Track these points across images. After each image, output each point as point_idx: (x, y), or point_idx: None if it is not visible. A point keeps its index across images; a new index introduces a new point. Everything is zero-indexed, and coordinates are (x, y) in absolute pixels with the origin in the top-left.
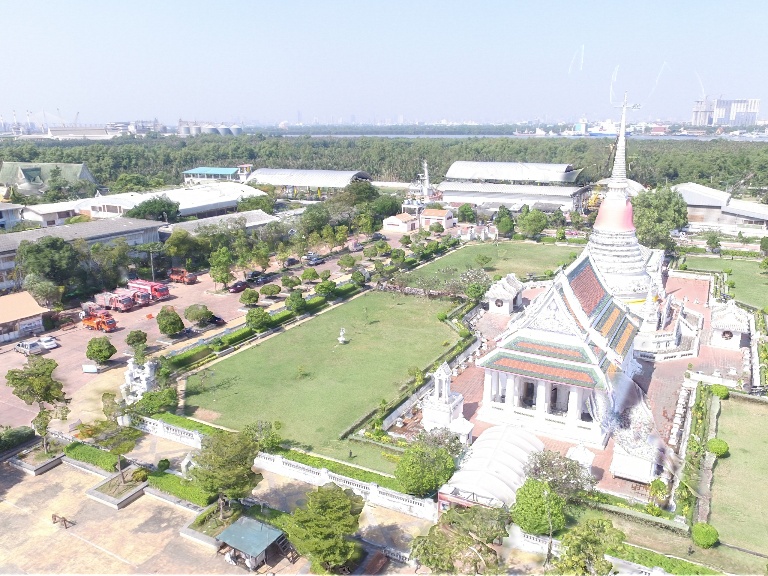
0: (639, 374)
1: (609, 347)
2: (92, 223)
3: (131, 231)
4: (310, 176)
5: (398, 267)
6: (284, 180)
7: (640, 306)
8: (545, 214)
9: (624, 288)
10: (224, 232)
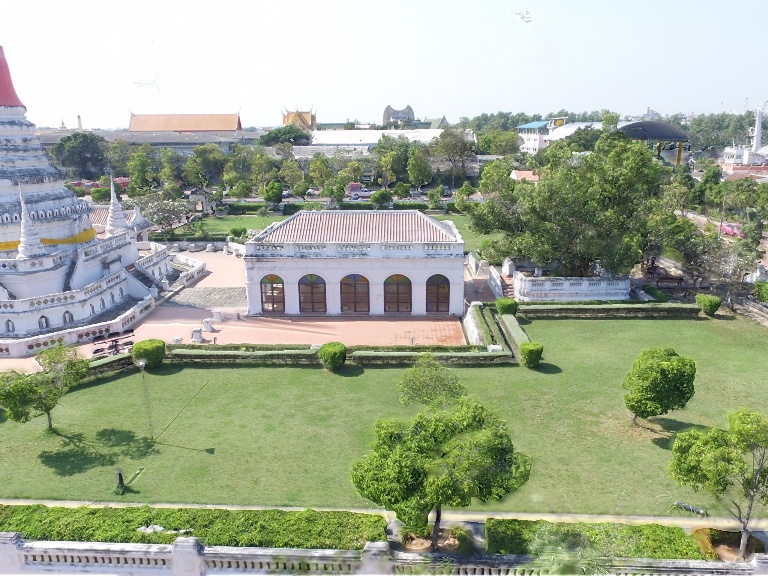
0: None
1: None
2: None
3: (186, 143)
4: None
5: (270, 207)
6: (568, 134)
7: None
8: (730, 187)
9: None
10: (248, 154)
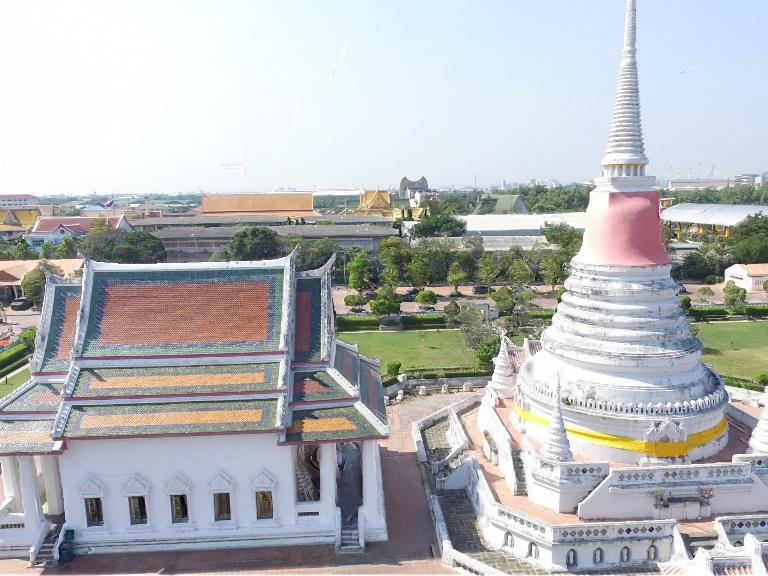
0: (335, 547)
1: (63, 402)
2: (337, 226)
3: (359, 236)
4: (724, 212)
5: None
6: (692, 216)
7: (579, 444)
8: None
9: (547, 389)
10: (440, 248)
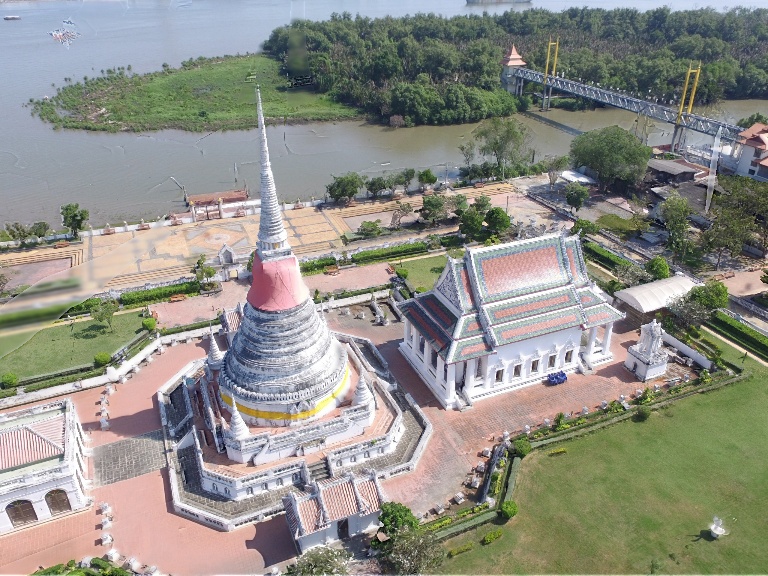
0: None
1: None
2: None
3: None
4: None
5: None
6: None
7: None
8: None
9: None
10: None
